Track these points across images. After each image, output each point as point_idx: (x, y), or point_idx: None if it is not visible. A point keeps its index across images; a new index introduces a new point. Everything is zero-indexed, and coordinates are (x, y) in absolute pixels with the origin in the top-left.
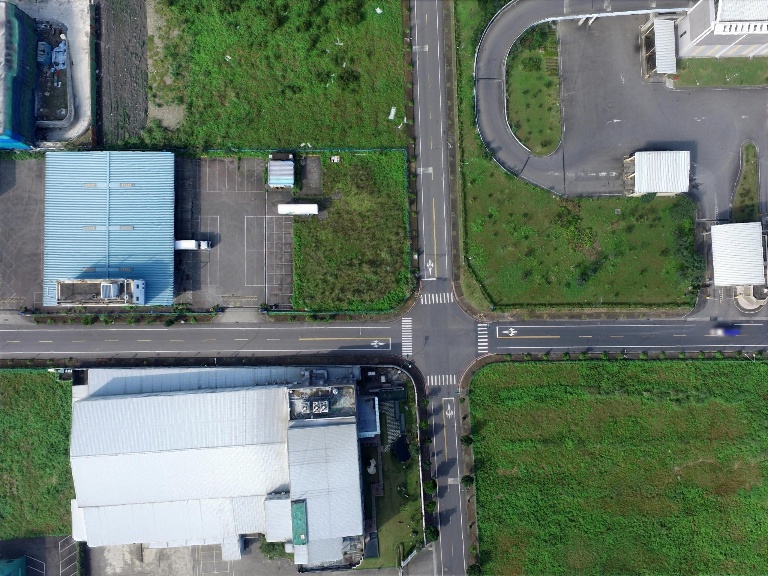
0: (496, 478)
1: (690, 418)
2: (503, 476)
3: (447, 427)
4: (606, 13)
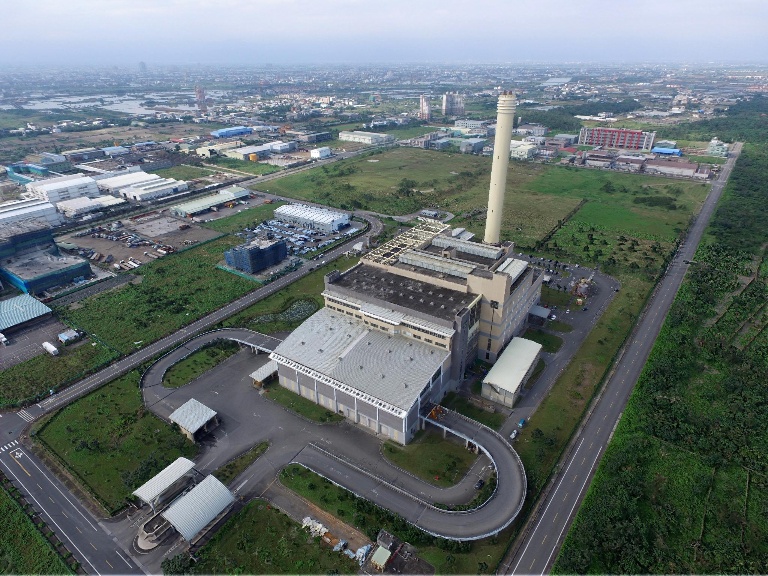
0: None
1: None
2: None
3: None
4: (257, 346)
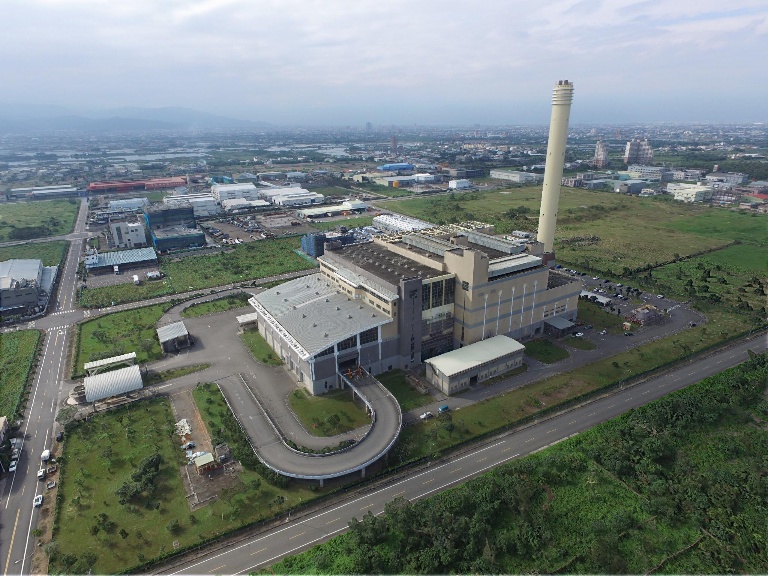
0: None
1: None
2: None
3: None
4: None
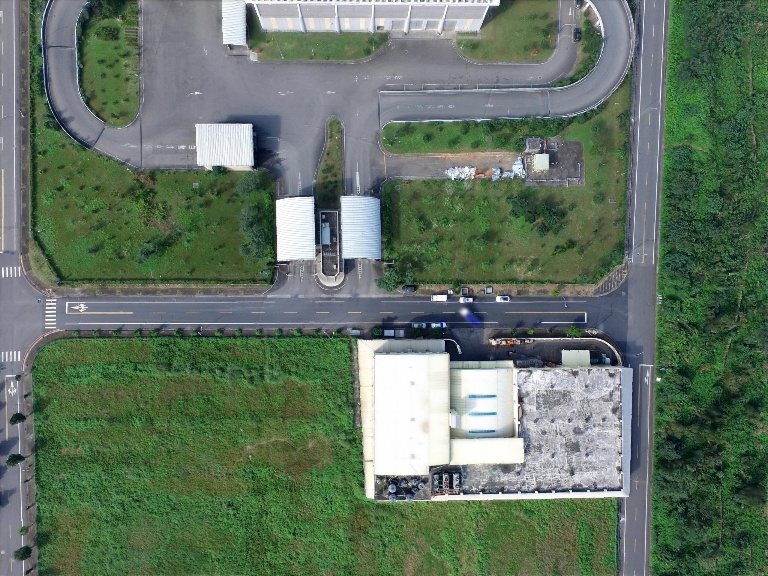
0: (58, 458)
1: (264, 396)
2: (66, 456)
3: (9, 405)
4: None
